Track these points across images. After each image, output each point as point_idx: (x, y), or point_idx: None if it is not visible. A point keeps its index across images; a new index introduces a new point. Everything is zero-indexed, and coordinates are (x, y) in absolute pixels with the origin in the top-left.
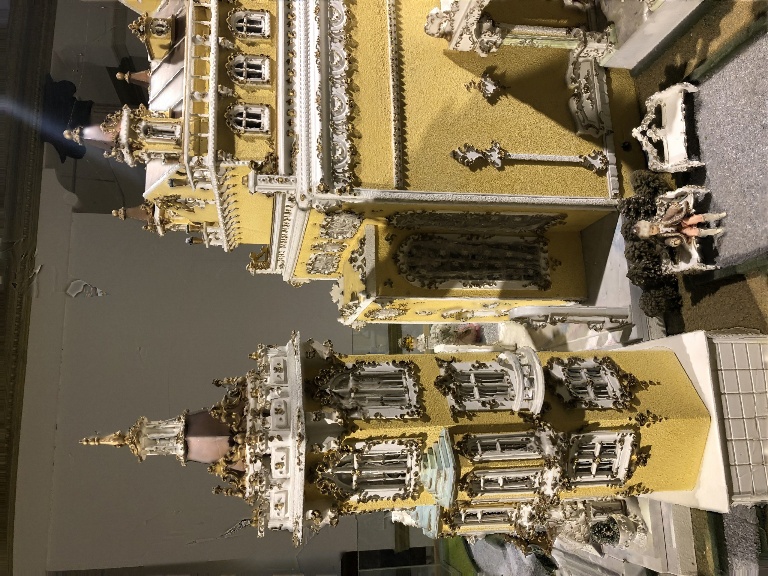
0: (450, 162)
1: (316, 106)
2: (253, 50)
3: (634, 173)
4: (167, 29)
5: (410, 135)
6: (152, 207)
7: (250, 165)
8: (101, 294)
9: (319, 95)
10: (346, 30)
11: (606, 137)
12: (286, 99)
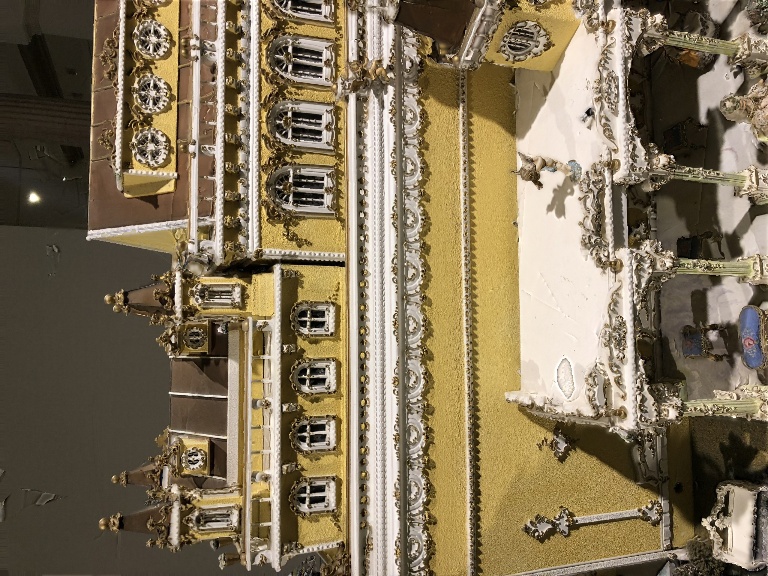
0: (521, 536)
1: (394, 501)
2: (317, 407)
3: (693, 543)
4: (203, 339)
5: (484, 512)
6: (159, 474)
7: (322, 573)
8: None
9: (398, 488)
10: (423, 394)
11: (662, 484)
12: (359, 485)
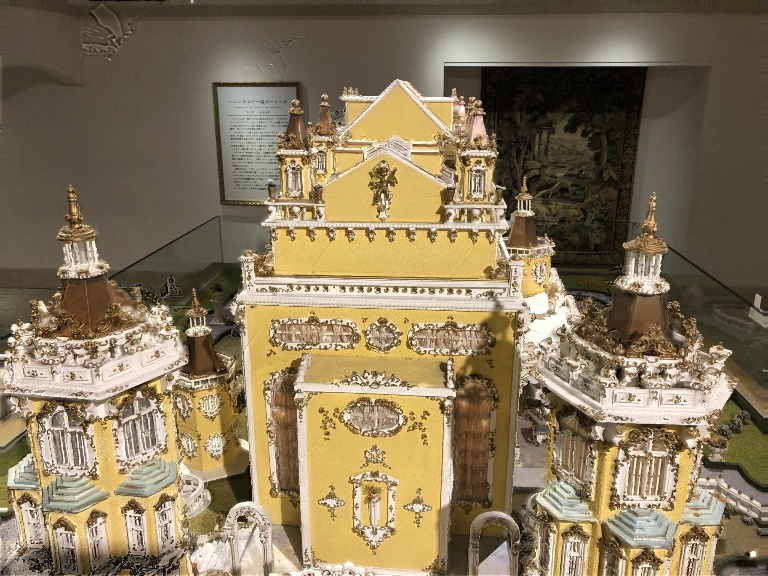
0: None
1: None
2: None
3: None
4: None
5: None
6: None
7: None
8: (86, 48)
9: None
10: None
11: None
12: None
